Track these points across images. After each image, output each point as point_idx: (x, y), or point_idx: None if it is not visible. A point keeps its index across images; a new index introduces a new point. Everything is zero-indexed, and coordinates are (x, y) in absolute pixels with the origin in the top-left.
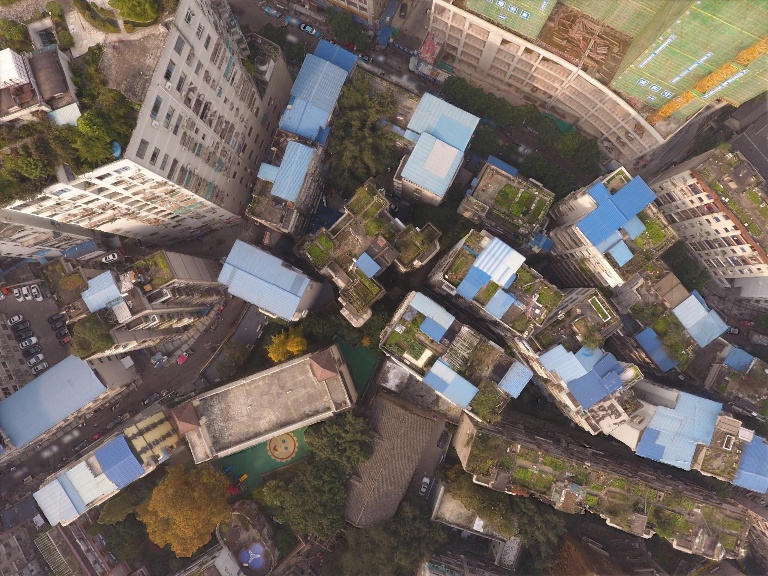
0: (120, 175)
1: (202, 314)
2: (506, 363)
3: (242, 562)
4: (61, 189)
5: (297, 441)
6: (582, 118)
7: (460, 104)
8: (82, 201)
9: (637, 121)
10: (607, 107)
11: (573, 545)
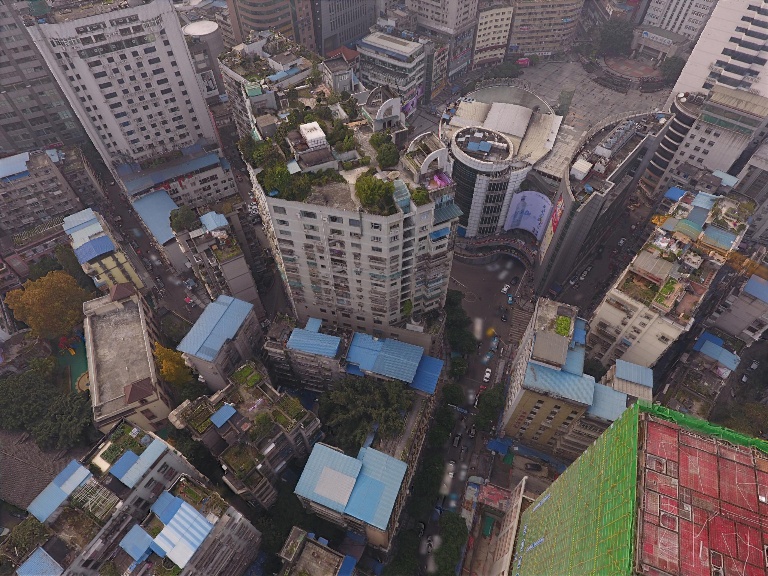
0: None
1: None
2: (67, 560)
3: None
4: None
5: None
6: None
7: (439, 539)
8: None
9: None
10: None
11: None
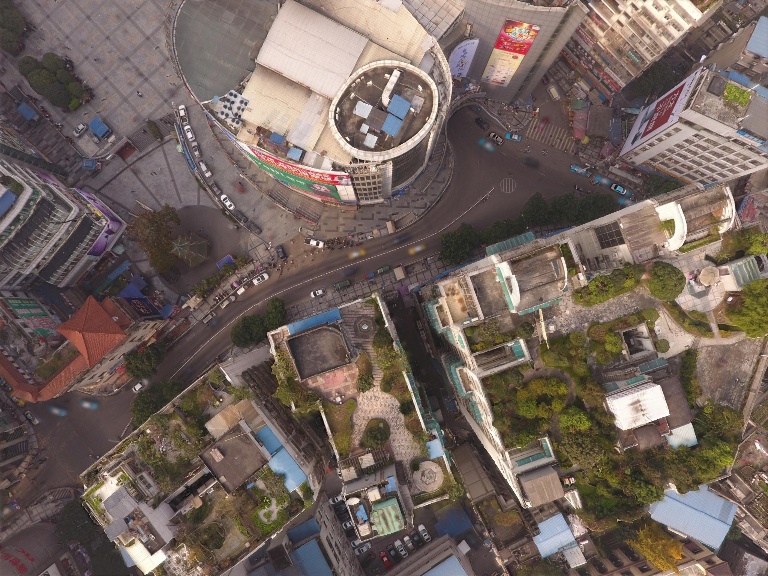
0: None
1: None
2: None
3: None
4: None
5: None
6: None
7: None
8: None
9: None
10: None
11: None
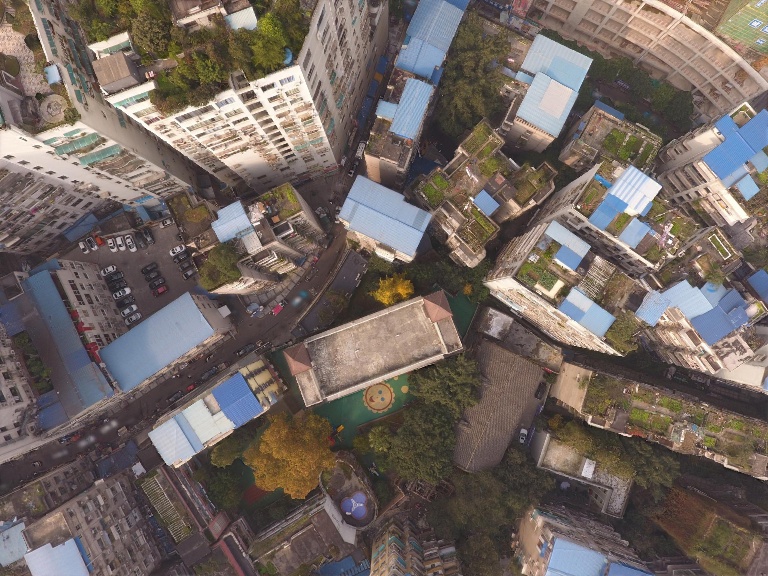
0: (281, 87)
1: (299, 263)
2: (640, 293)
3: (344, 511)
4: (227, 98)
5: (394, 392)
6: (673, 72)
7: None
8: (234, 119)
9: (740, 68)
10: (707, 56)
11: (683, 492)
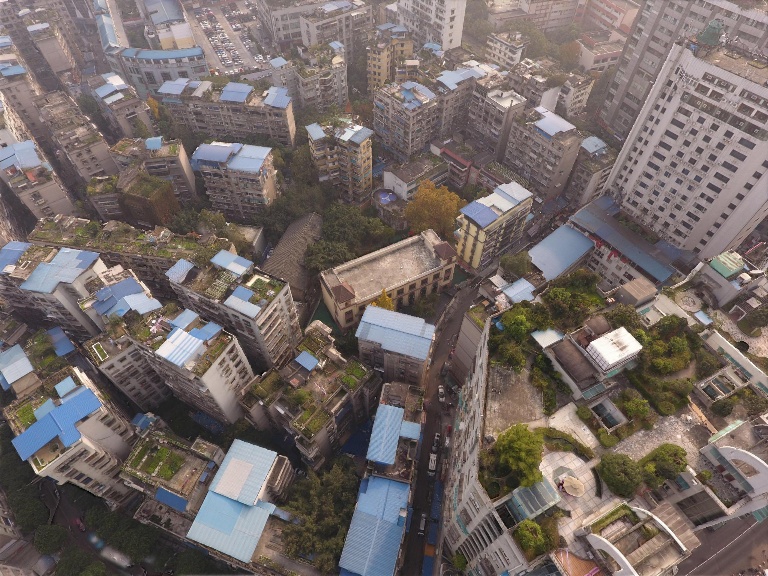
0: None
1: None
2: (187, 283)
3: (394, 195)
4: None
5: None
6: None
7: None
8: None
9: None
10: None
11: (162, 223)
